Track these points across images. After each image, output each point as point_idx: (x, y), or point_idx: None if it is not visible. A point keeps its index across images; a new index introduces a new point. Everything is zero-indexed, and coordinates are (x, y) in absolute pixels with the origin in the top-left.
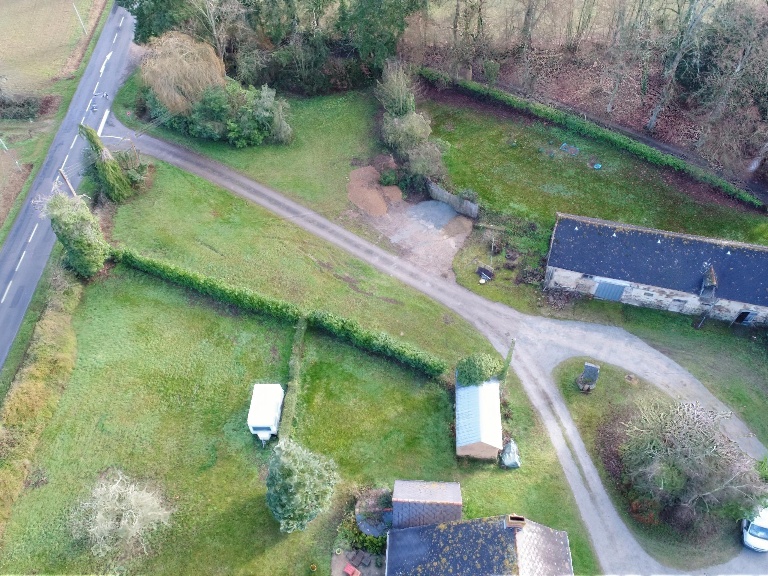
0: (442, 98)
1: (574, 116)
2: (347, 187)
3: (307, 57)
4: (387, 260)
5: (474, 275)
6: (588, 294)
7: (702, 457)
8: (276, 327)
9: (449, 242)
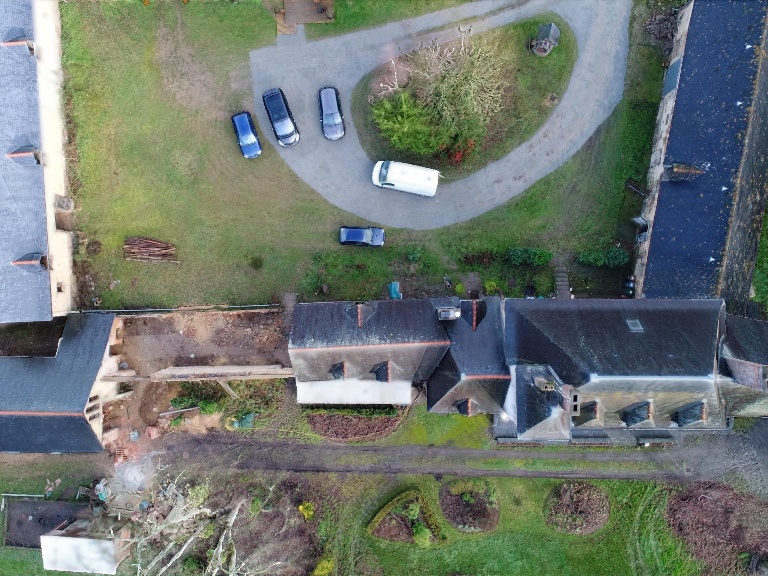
0: None
1: None
2: None
3: None
4: None
5: None
6: (669, 59)
7: (428, 78)
8: None
9: None
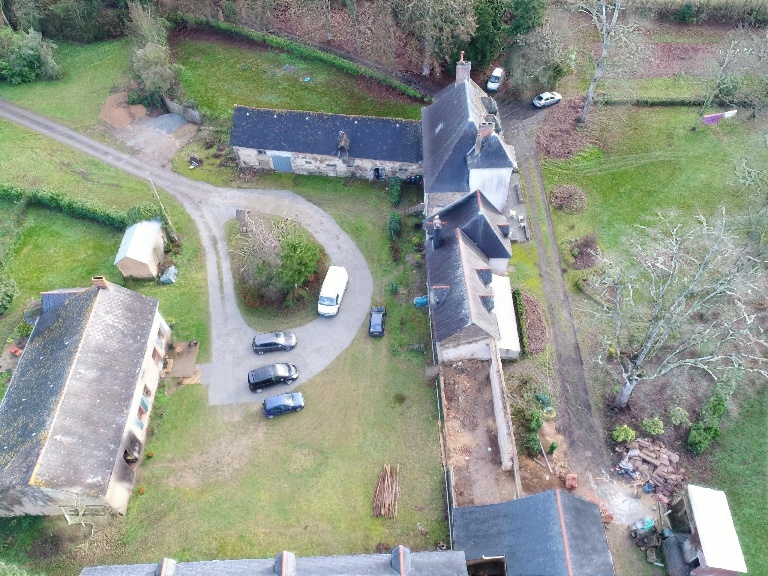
0: (198, 37)
1: (297, 43)
2: (101, 108)
3: (80, 8)
4: (119, 158)
5: (187, 164)
6: (269, 169)
7: (267, 244)
8: (7, 206)
9: (175, 142)
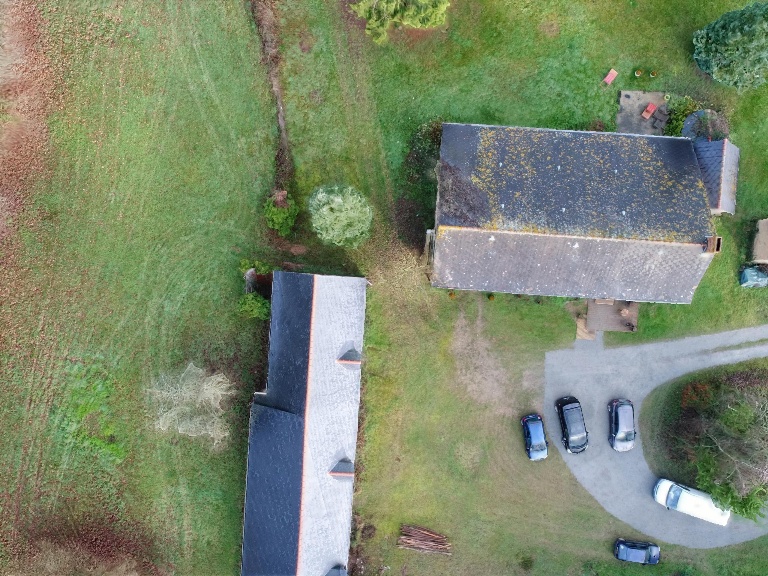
0: None
1: None
2: None
3: None
4: None
5: None
6: None
7: (765, 452)
8: None
9: None
